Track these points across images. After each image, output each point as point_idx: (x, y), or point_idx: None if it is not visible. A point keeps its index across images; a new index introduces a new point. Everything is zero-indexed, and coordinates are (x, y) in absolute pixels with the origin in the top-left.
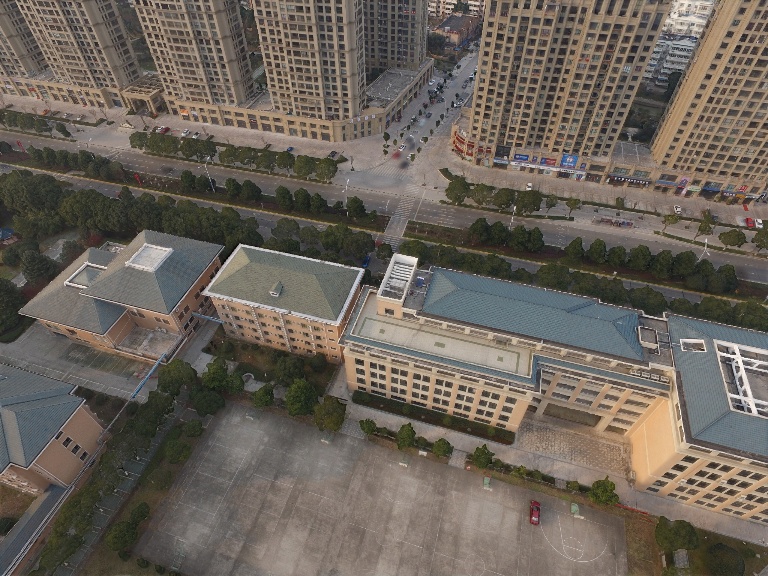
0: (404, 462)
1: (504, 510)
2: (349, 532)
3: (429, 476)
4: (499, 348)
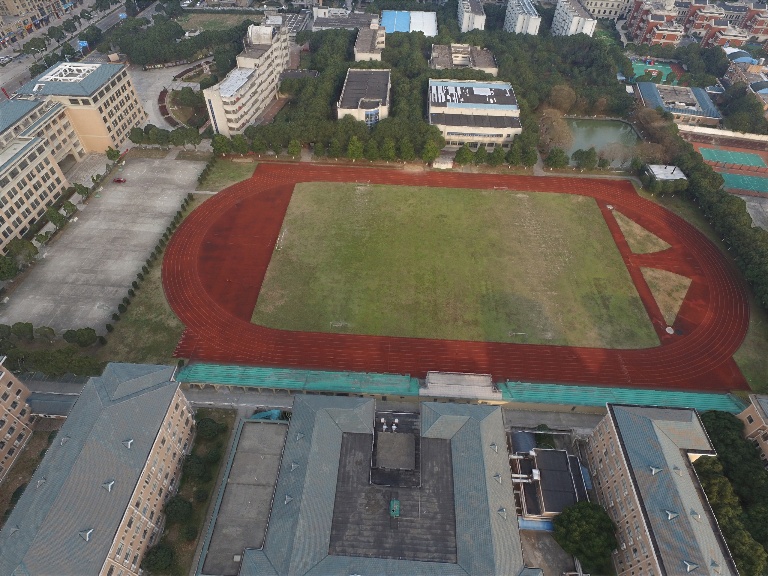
0: (74, 218)
1: (115, 191)
2: (113, 243)
3: (87, 217)
4: (6, 149)
